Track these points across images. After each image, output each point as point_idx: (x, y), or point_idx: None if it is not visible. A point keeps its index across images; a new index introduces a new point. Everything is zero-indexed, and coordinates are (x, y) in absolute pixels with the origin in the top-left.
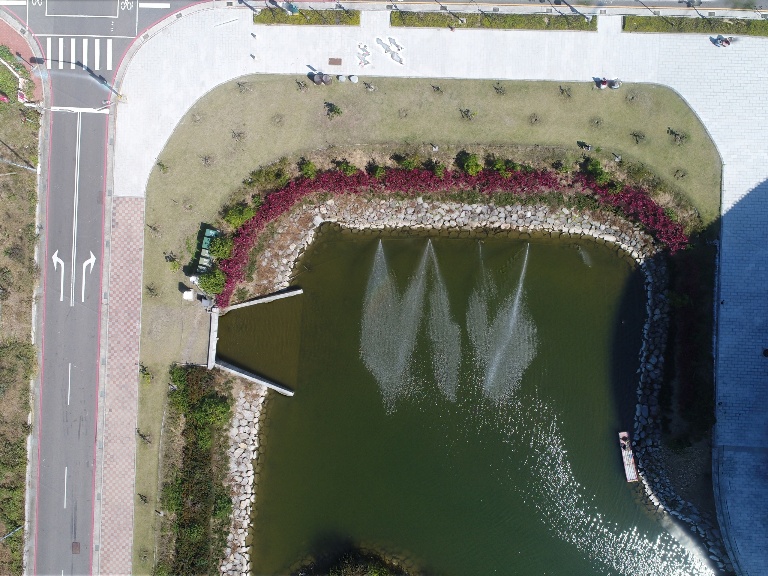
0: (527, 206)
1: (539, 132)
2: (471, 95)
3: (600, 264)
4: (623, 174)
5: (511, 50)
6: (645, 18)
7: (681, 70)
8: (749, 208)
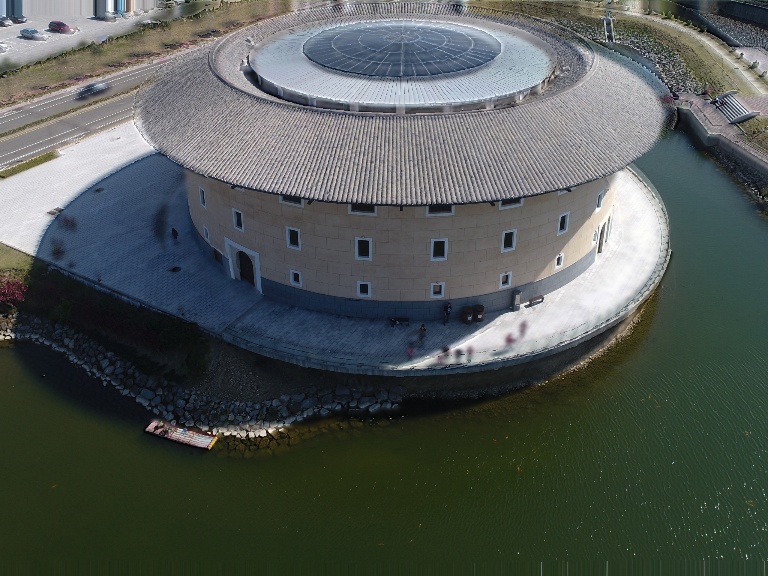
0: None
1: None
2: None
3: None
4: None
5: None
6: None
7: None
8: (53, 240)
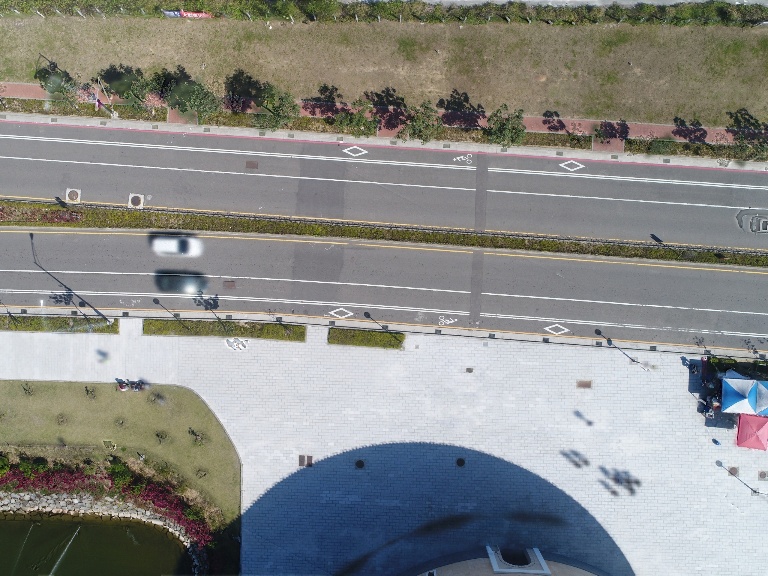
0: (72, 494)
1: (66, 432)
2: (1, 395)
3: (153, 545)
4: (152, 470)
5: (38, 352)
6: (163, 322)
7: (200, 372)
8: (267, 508)
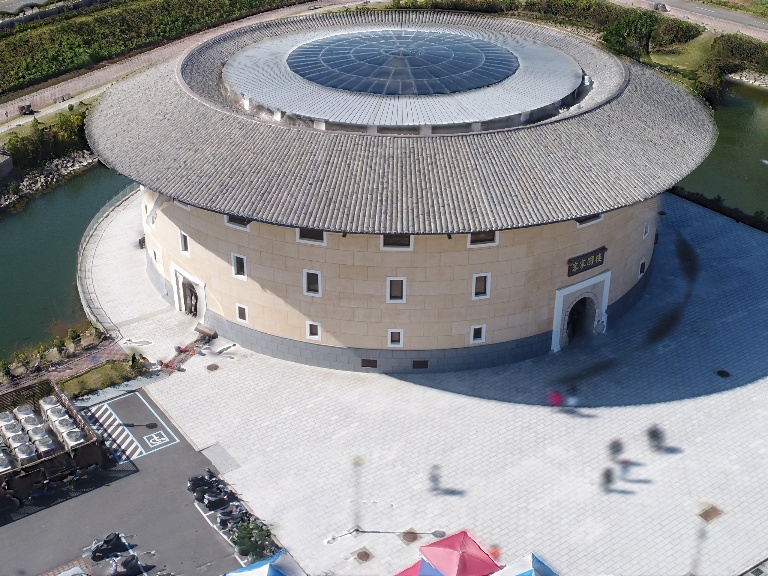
0: None
1: None
2: None
3: None
4: None
5: None
6: None
7: None
8: None
